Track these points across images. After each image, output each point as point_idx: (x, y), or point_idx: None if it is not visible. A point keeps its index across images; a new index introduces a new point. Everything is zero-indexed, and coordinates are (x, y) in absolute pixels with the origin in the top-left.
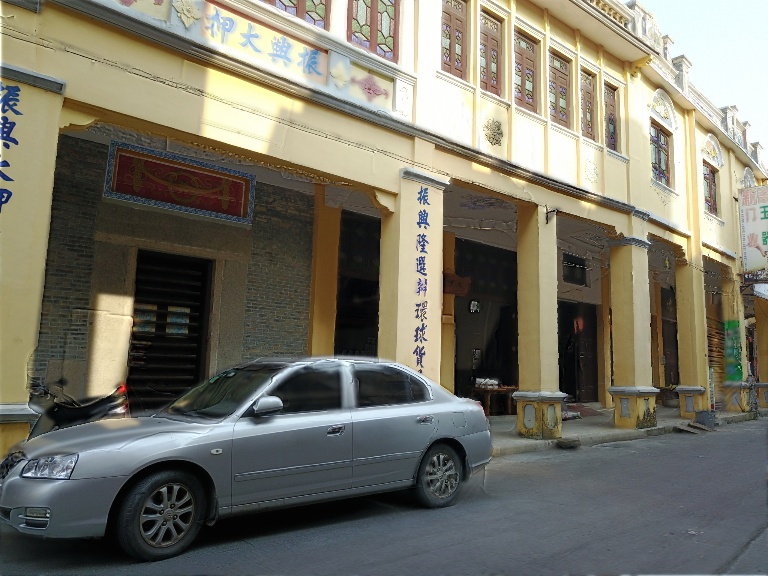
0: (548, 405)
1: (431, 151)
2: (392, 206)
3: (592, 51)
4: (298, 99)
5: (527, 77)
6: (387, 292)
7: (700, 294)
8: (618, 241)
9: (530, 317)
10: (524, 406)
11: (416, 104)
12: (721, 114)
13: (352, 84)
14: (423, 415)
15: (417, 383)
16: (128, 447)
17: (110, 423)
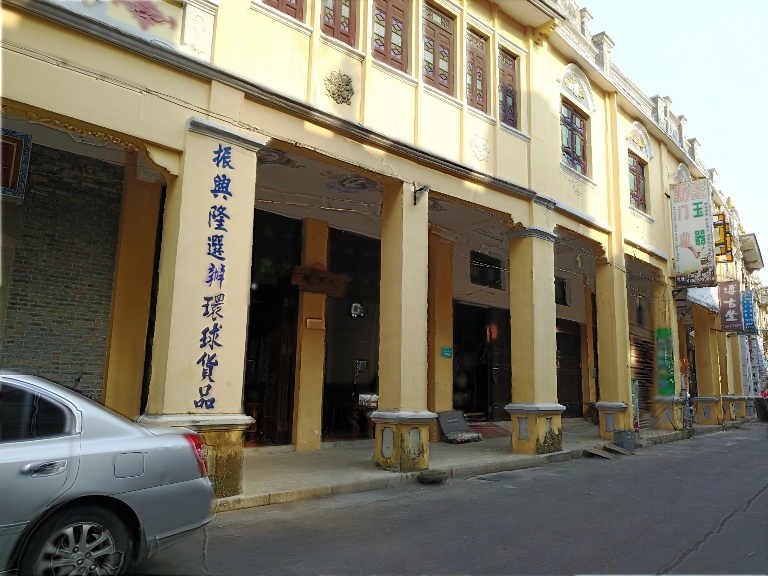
0: (410, 428)
1: (238, 100)
2: (174, 167)
3: (483, 9)
4: (7, 7)
5: (394, 29)
6: (165, 281)
7: (621, 297)
8: (518, 232)
9: (392, 319)
10: (382, 430)
11: (215, 38)
12: (651, 103)
13: (113, 2)
14: (39, 461)
15: (55, 407)
16: None
17: None
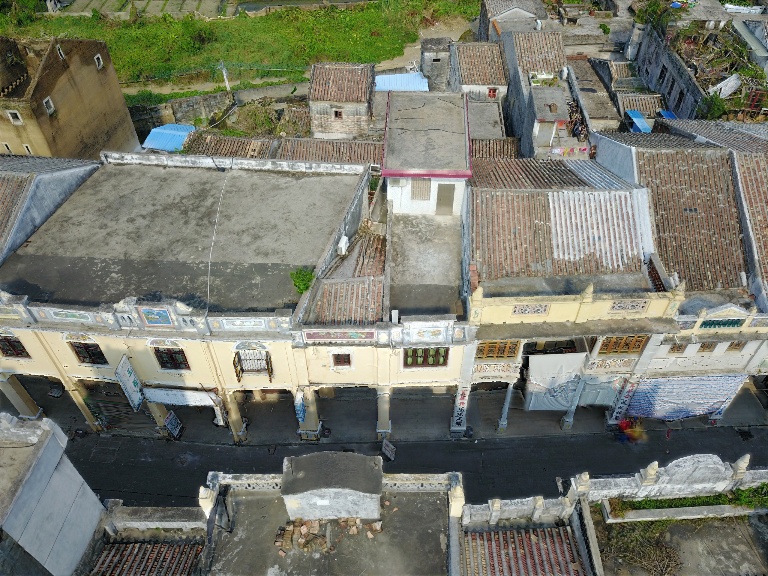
0: None
1: None
2: None
3: None
4: None
5: None
6: None
7: None
8: None
9: None
10: None
11: None
12: None
13: None
14: None
15: None
16: None
17: None
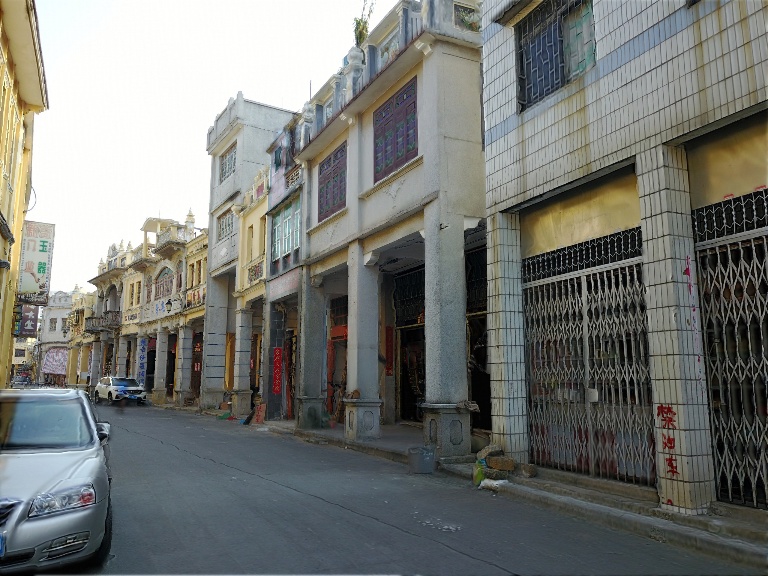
0: None
1: None
2: None
3: (14, 86)
4: None
5: None
6: None
7: (10, 313)
8: None
9: None
10: None
11: None
12: None
13: None
14: None
15: None
16: (78, 475)
17: (0, 463)
